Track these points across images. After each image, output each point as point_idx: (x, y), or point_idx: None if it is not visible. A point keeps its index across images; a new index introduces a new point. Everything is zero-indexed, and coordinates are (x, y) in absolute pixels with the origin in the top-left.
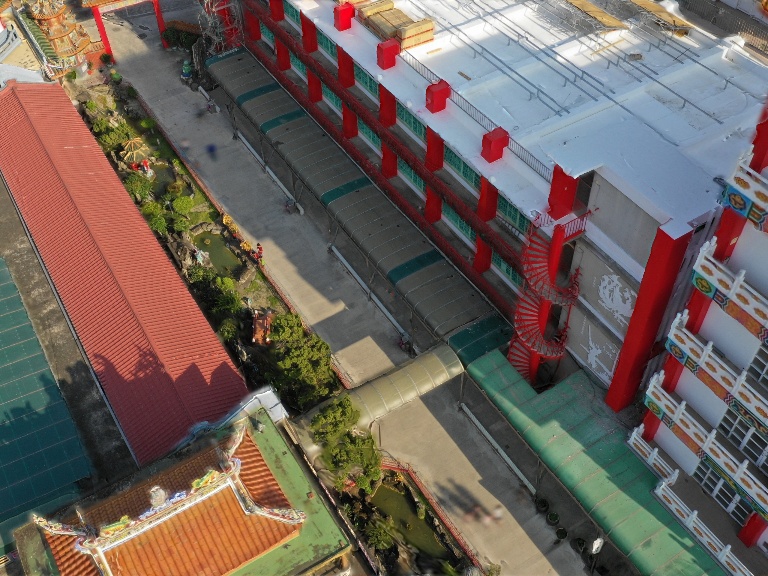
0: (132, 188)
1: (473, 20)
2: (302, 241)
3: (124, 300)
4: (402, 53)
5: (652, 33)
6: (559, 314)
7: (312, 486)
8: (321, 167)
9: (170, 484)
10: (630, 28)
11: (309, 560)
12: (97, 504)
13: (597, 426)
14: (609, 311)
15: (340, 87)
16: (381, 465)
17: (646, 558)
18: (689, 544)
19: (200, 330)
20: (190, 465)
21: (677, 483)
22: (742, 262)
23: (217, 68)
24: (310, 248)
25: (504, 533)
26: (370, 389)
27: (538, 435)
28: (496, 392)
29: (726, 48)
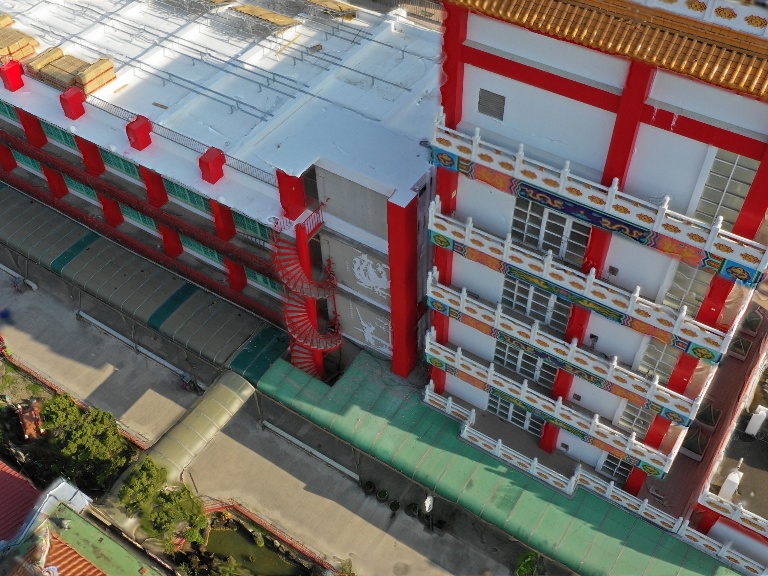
0: None
1: (150, 49)
2: (45, 317)
3: None
4: (88, 99)
5: (324, 23)
6: (326, 306)
7: (141, 561)
8: (40, 236)
9: None
10: (303, 22)
11: None
12: None
13: (393, 397)
14: (369, 289)
15: (33, 149)
16: (204, 511)
17: (473, 498)
18: (504, 470)
19: None
20: None
21: (477, 421)
22: (466, 211)
23: None
24: (56, 321)
25: (343, 527)
26: (168, 442)
27: (344, 425)
28: (292, 399)
29: (392, 22)
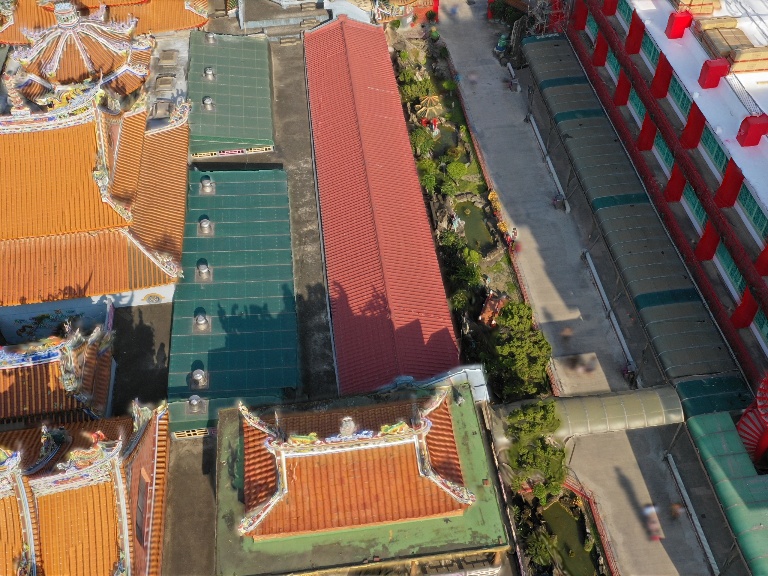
0: (416, 141)
1: None
2: (558, 238)
3: (375, 241)
4: (729, 76)
5: None
6: None
7: (490, 475)
8: (602, 171)
9: (362, 420)
10: None
11: (464, 542)
12: (294, 414)
13: None
14: None
15: (650, 96)
16: (564, 482)
17: None
18: None
19: (434, 291)
20: (385, 410)
21: None
22: None
23: (531, 48)
24: (564, 248)
25: None
26: (578, 404)
27: (743, 517)
28: (711, 455)
29: None
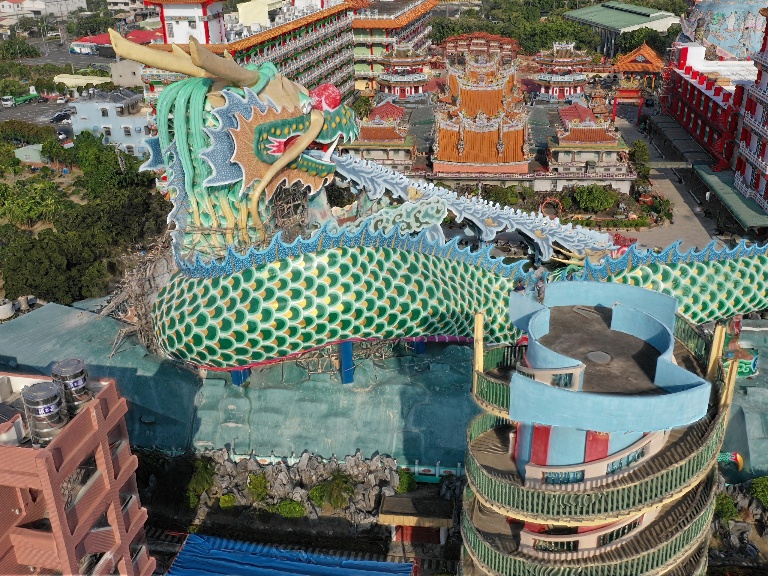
0: None
1: None
2: None
3: None
4: None
5: None
6: (732, 154)
7: None
8: (677, 135)
9: None
10: None
11: None
12: None
13: None
14: None
15: None
16: (652, 193)
17: (719, 190)
18: None
19: None
20: None
21: None
22: None
23: None
24: None
25: None
26: None
27: None
28: (699, 169)
29: None
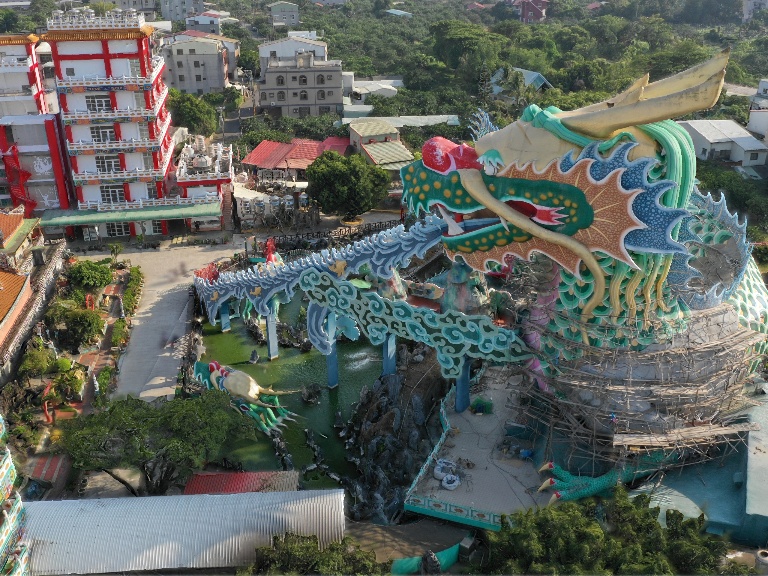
0: None
1: None
2: None
3: None
4: None
5: None
6: None
7: None
8: None
9: None
10: None
11: None
12: None
13: (67, 213)
14: (43, 174)
15: None
16: None
17: (111, 218)
18: None
19: None
20: None
21: None
22: None
23: None
24: None
25: None
26: None
27: (53, 221)
28: None
29: None
